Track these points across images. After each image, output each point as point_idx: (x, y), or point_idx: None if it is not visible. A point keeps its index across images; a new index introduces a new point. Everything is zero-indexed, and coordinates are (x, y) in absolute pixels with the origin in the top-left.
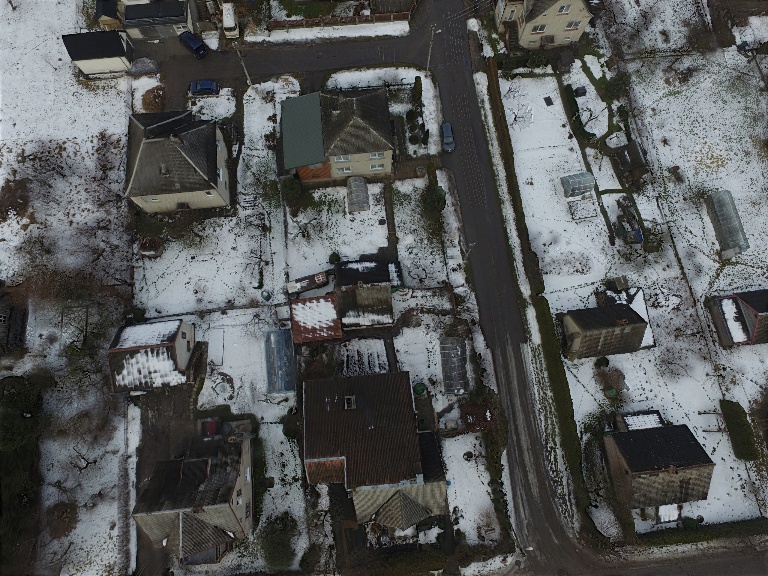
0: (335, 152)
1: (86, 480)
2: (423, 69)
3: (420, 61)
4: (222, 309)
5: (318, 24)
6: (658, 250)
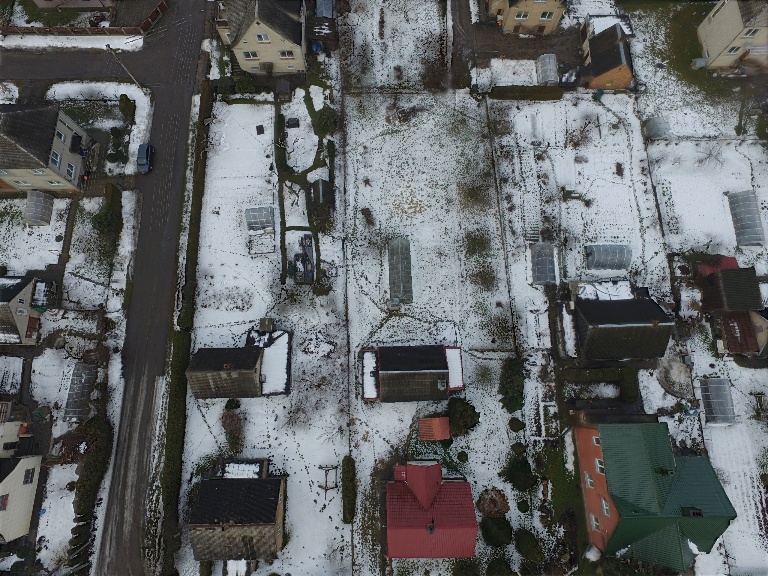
0: None
1: None
2: (144, 86)
3: (144, 78)
4: None
5: (51, 32)
6: (327, 293)
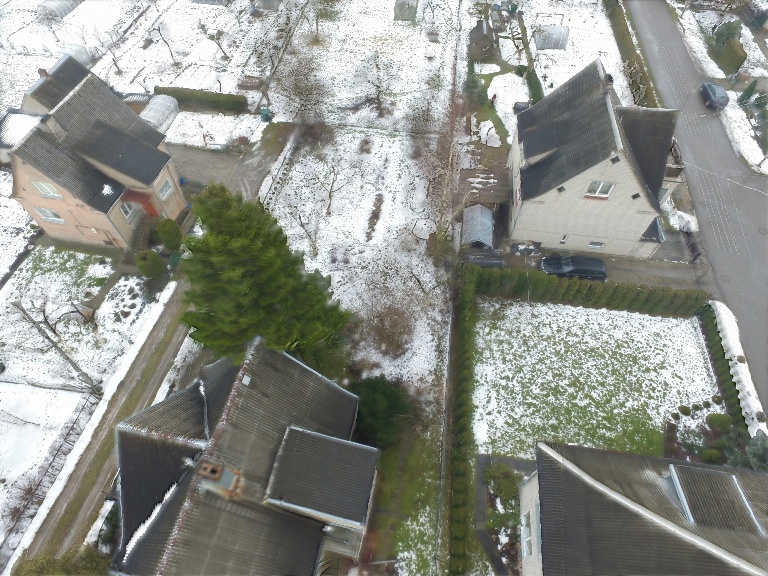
0: None
1: None
2: (766, 176)
3: None
4: None
5: None
6: (478, 3)
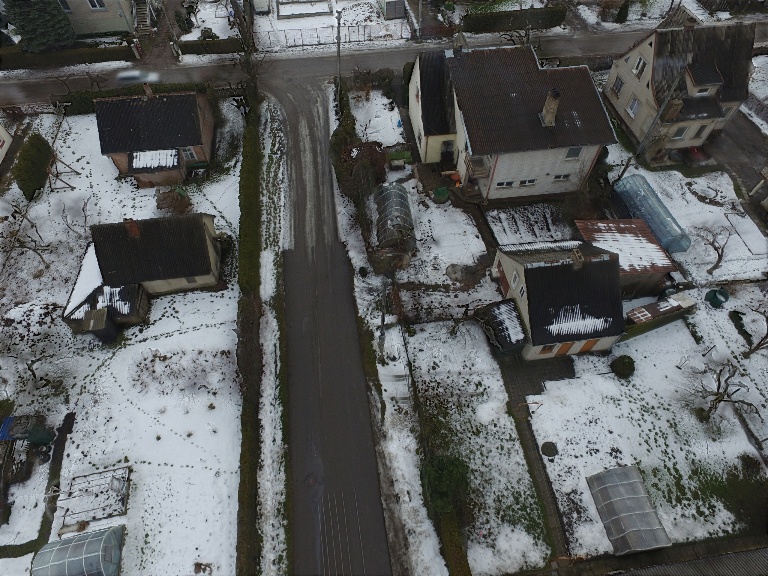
0: None
1: None
2: None
3: None
4: None
5: None
6: None
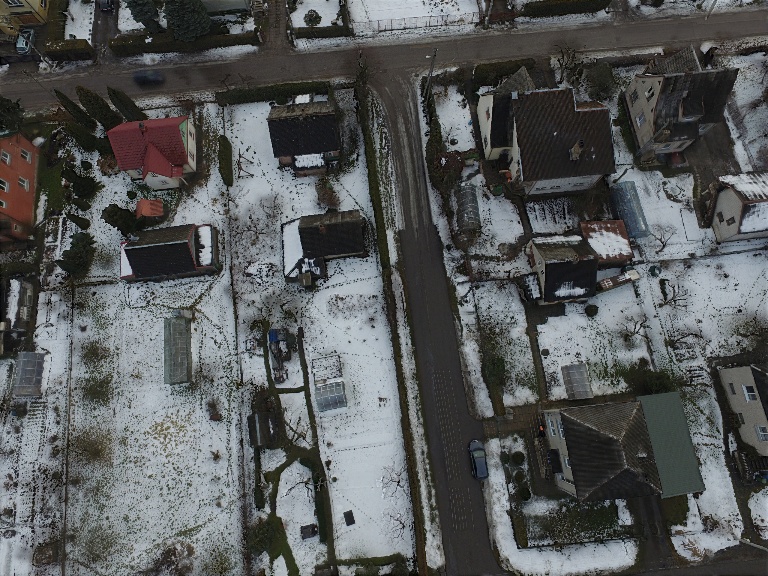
0: (629, 406)
1: (767, 123)
2: (512, 573)
3: None
4: (695, 259)
5: None
6: None
